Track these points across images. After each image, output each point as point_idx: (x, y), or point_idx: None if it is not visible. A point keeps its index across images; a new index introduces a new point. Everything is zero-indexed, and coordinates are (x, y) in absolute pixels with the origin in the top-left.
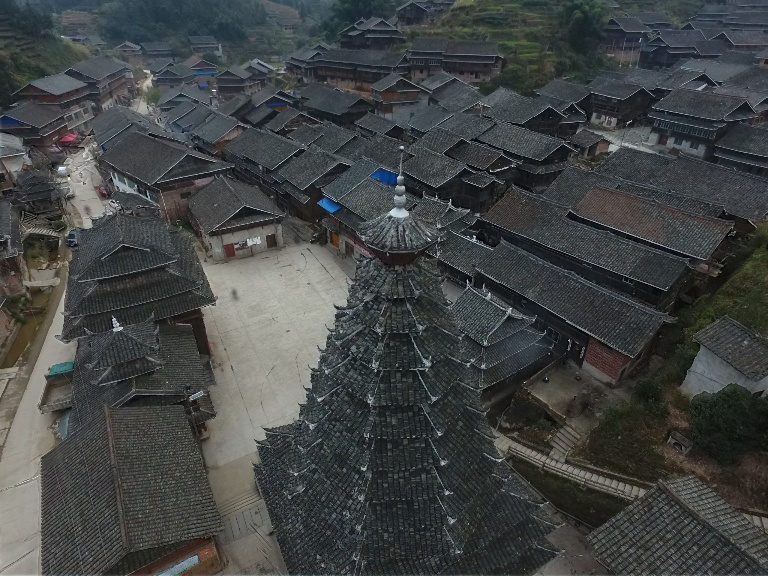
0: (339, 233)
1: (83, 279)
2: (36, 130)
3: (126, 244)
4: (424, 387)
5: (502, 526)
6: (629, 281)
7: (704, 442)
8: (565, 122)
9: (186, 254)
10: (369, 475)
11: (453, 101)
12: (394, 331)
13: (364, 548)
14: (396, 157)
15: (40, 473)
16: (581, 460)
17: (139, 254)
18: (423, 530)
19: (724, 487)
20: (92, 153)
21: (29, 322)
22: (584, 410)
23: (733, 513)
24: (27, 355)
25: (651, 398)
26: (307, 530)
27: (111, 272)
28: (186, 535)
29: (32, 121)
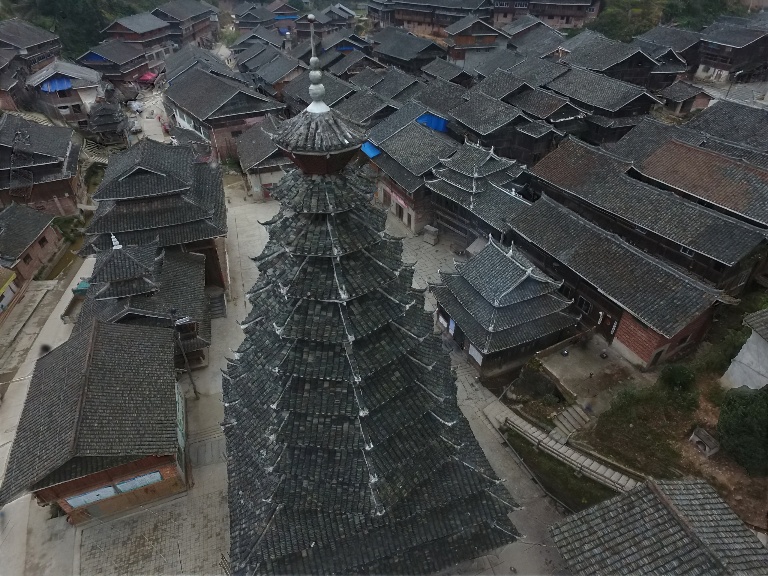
0: (378, 180)
1: (99, 198)
2: (117, 67)
3: (142, 167)
4: (343, 324)
5: (446, 496)
6: (688, 252)
7: (730, 444)
8: (658, 72)
9: (209, 185)
10: (285, 415)
11: (532, 47)
12: (305, 252)
13: (278, 491)
14: (452, 103)
15: (32, 373)
16: (584, 444)
17: (155, 178)
18: (347, 484)
19: (751, 501)
20: (160, 89)
21: (78, 242)
22: (602, 391)
23: (743, 532)
24: (67, 271)
25: (678, 386)
26: (238, 464)
27: (126, 193)
28: (136, 450)
29: (114, 58)
